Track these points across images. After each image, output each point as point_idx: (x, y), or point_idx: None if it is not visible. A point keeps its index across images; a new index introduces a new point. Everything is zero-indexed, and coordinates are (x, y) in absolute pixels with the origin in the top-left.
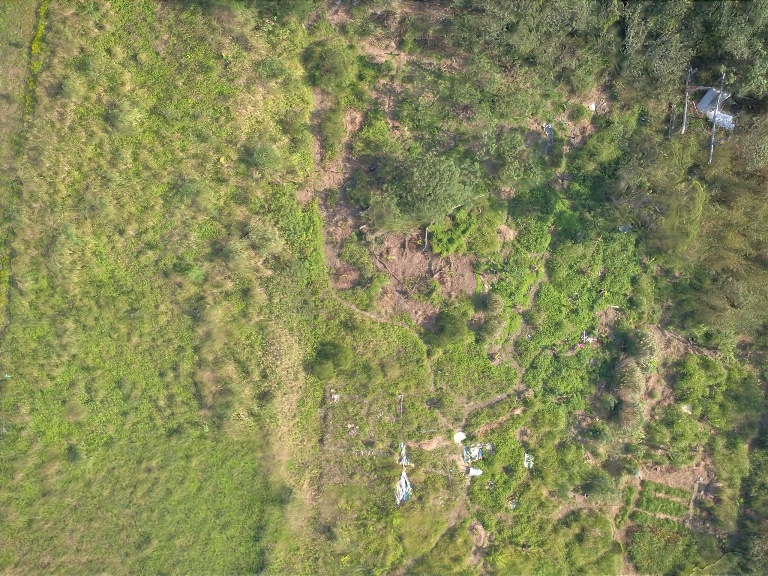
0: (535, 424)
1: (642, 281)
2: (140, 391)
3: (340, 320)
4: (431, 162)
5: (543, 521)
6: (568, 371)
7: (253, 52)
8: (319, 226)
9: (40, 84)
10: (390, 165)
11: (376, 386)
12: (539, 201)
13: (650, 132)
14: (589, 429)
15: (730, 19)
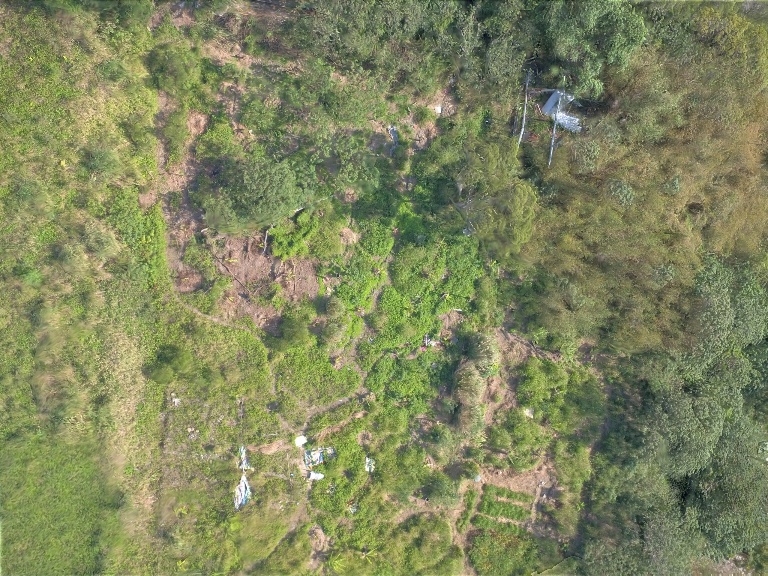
0: (376, 428)
1: (484, 284)
2: None
3: (181, 323)
4: (262, 165)
5: (383, 525)
6: (409, 374)
7: (95, 55)
8: (162, 229)
9: None
10: (233, 168)
11: (216, 390)
12: (381, 204)
13: (494, 134)
14: (430, 433)
15: (559, 21)
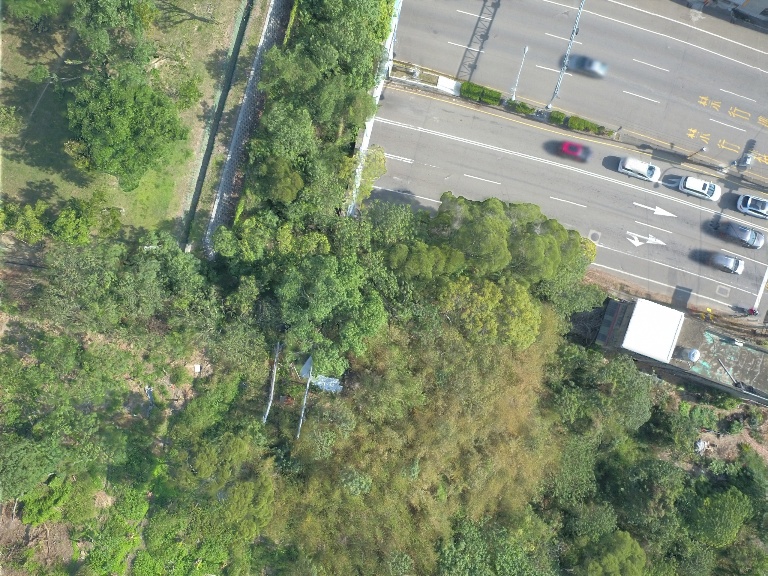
0: None
1: (237, 551)
2: None
3: None
4: None
5: None
6: None
7: None
8: None
9: None
10: None
11: None
12: (135, 469)
13: (250, 397)
14: None
15: (293, 310)
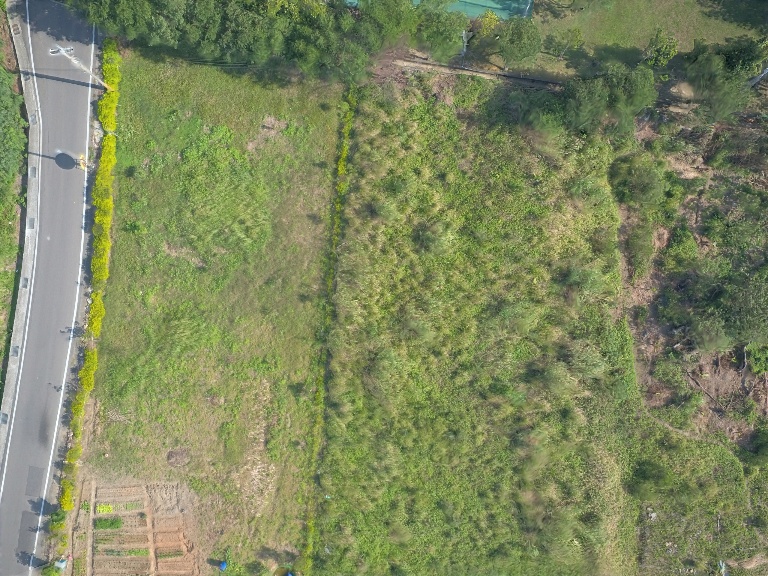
0: None
1: None
2: (459, 511)
3: (655, 438)
4: (765, 288)
5: None
6: None
7: (563, 171)
8: (630, 344)
9: (349, 206)
10: (702, 282)
11: (693, 505)
12: None
13: None
14: None
15: None
